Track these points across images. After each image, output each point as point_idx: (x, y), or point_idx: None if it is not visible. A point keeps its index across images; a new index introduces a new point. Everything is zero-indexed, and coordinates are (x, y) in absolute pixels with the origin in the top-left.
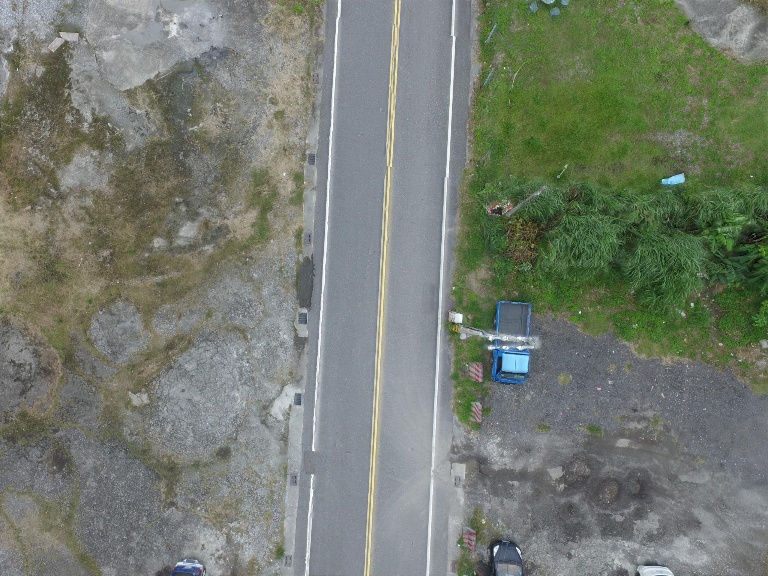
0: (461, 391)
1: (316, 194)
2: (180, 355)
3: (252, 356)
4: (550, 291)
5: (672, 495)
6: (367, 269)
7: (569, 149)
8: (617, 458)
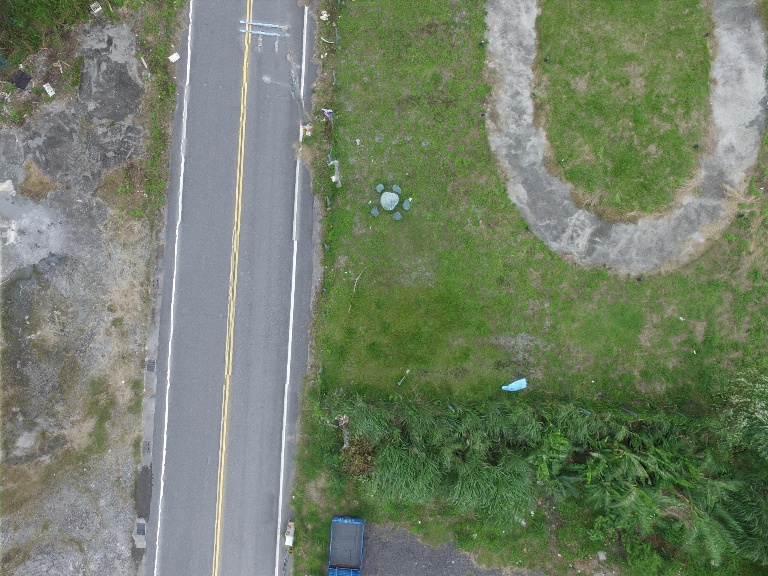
0: None
1: (155, 401)
2: (15, 569)
3: (89, 569)
4: (389, 501)
5: None
6: (205, 479)
7: (411, 354)
8: None
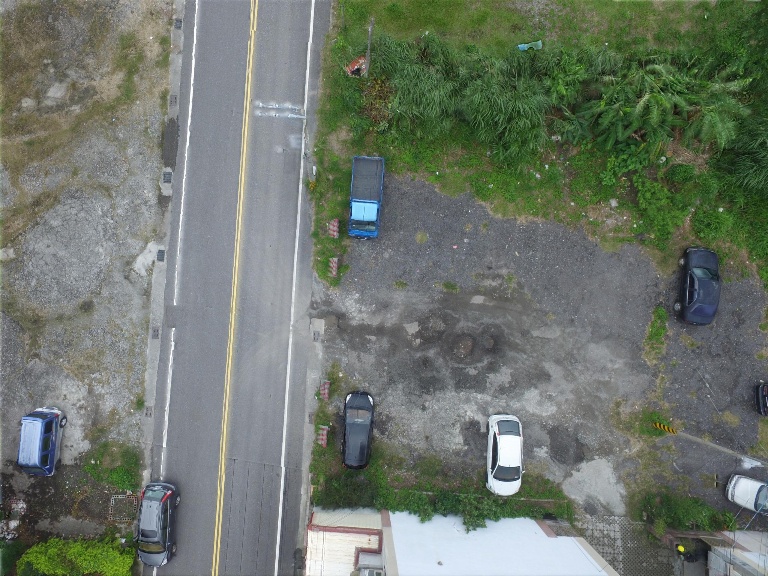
0: (321, 248)
1: (182, 58)
2: (46, 212)
3: (117, 213)
4: (408, 152)
5: (524, 350)
6: (230, 130)
7: (430, 17)
8: (472, 314)
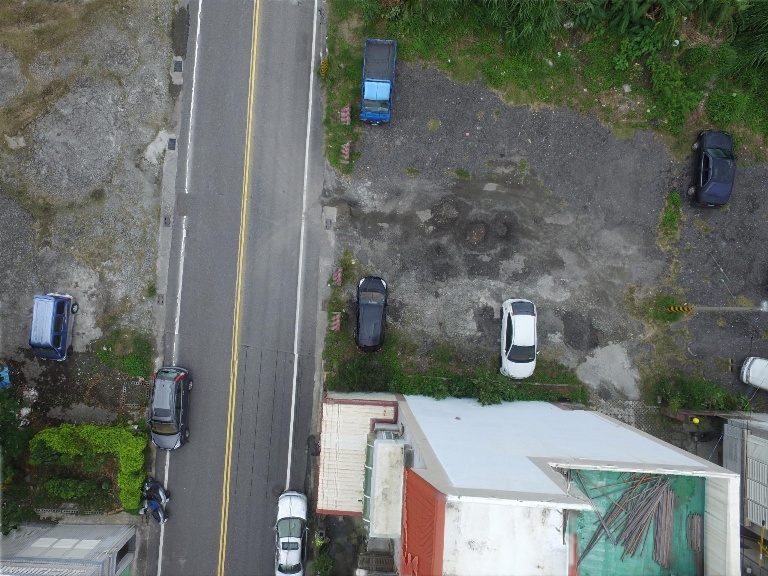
0: (332, 136)
1: None
2: (56, 100)
3: (127, 102)
4: (420, 39)
5: (538, 236)
6: (241, 18)
7: None
8: (484, 201)
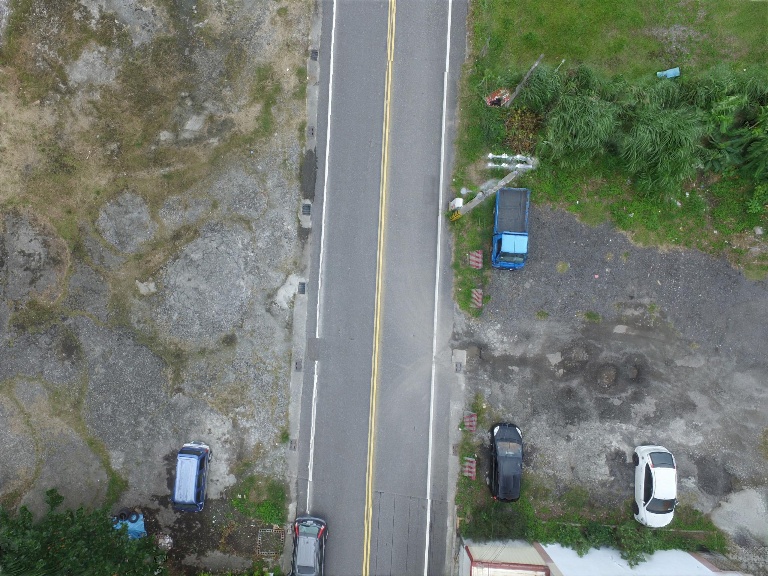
0: (462, 279)
1: (319, 89)
2: (186, 245)
3: (257, 246)
4: (548, 181)
5: (668, 379)
6: (369, 161)
7: (566, 44)
8: (615, 344)
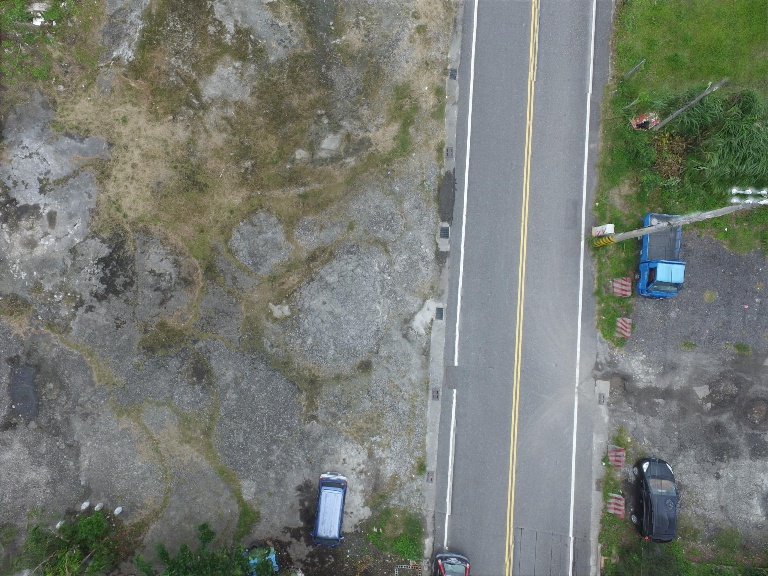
0: (606, 307)
1: (458, 108)
2: (321, 267)
3: (394, 269)
4: (696, 207)
5: None
6: (510, 183)
7: (713, 67)
8: (765, 377)
